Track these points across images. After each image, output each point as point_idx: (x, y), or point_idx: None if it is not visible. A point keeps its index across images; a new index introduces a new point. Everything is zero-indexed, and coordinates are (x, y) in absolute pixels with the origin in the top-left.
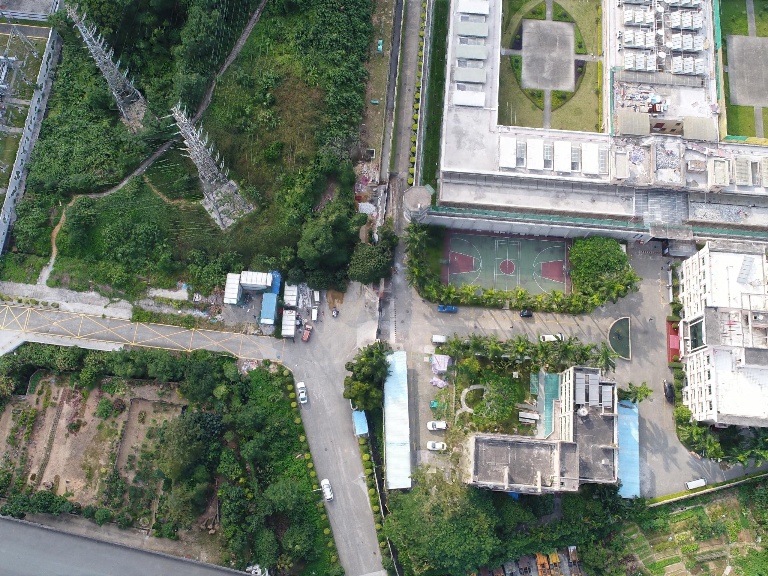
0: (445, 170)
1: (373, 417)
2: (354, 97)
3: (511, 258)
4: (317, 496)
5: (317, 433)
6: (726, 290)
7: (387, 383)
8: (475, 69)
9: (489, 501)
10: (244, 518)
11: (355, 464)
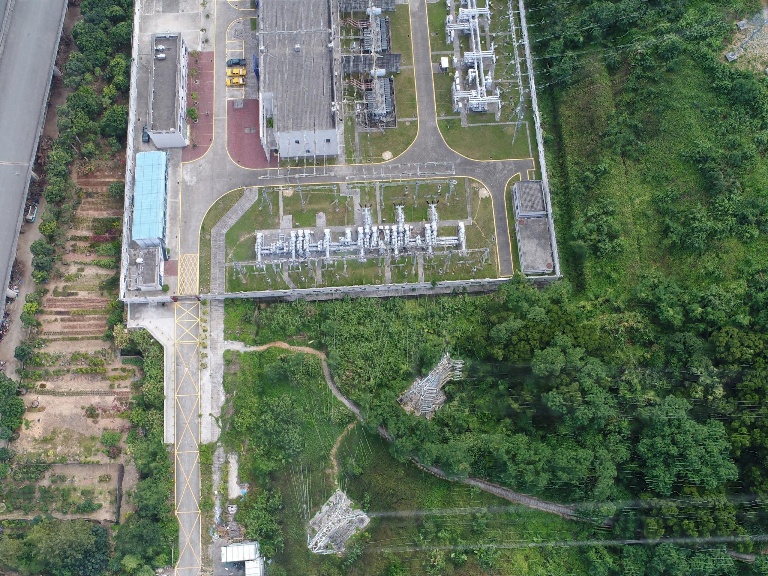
0: None
1: None
2: None
3: None
4: None
5: None
6: None
7: None
8: None
9: None
10: None
11: None
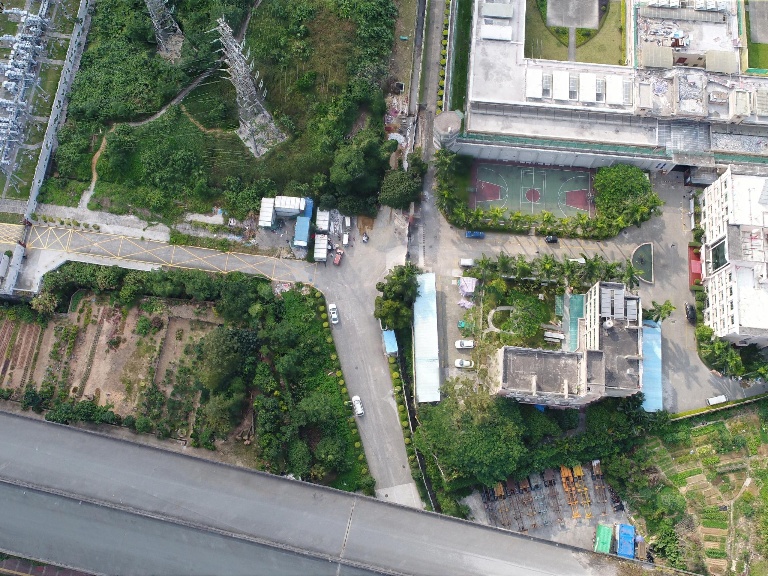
0: (473, 100)
1: (402, 338)
2: (384, 31)
3: (536, 187)
4: (348, 411)
5: (348, 352)
6: (748, 211)
7: (416, 303)
8: (502, 5)
9: (517, 410)
10: (279, 428)
11: (385, 382)
